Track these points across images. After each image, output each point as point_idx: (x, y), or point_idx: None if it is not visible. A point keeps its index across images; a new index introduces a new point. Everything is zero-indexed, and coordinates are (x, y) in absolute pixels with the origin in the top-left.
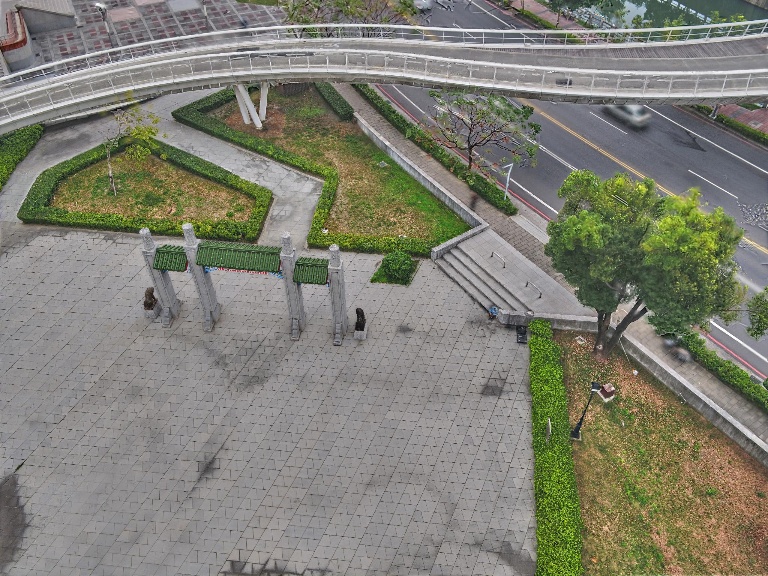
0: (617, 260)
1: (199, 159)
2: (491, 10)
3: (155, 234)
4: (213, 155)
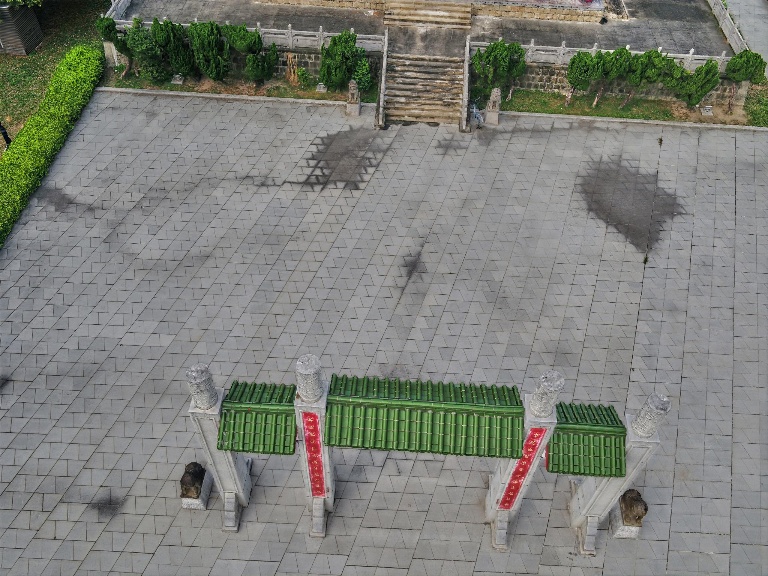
0: None
1: None
2: None
3: None
4: None
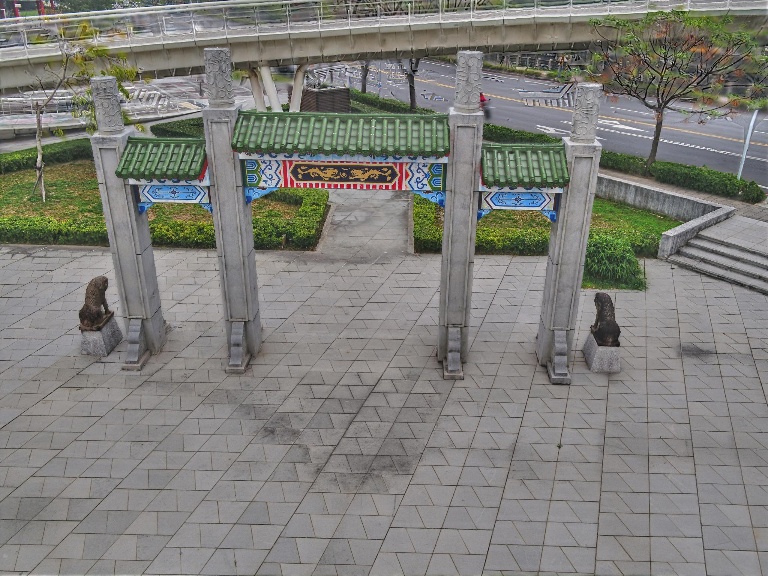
0: None
1: None
2: (549, 83)
3: None
4: None
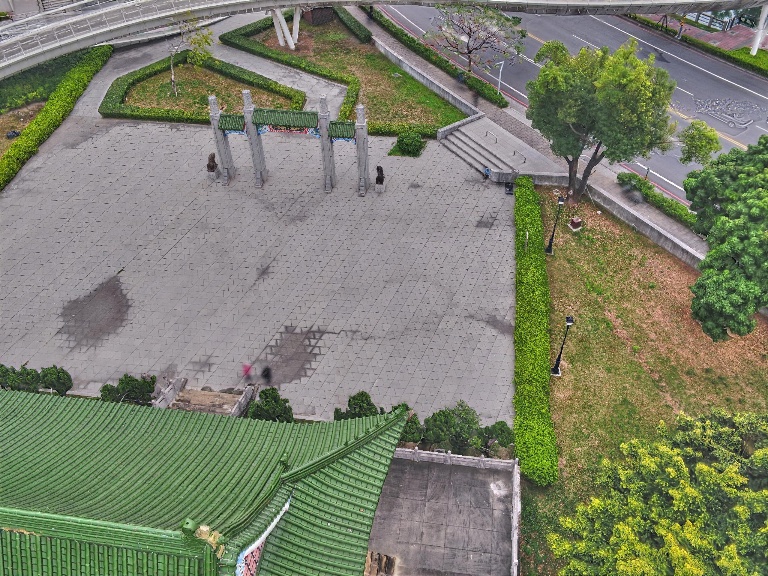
0: (578, 103)
1: (244, 70)
2: None
3: None
4: (255, 68)
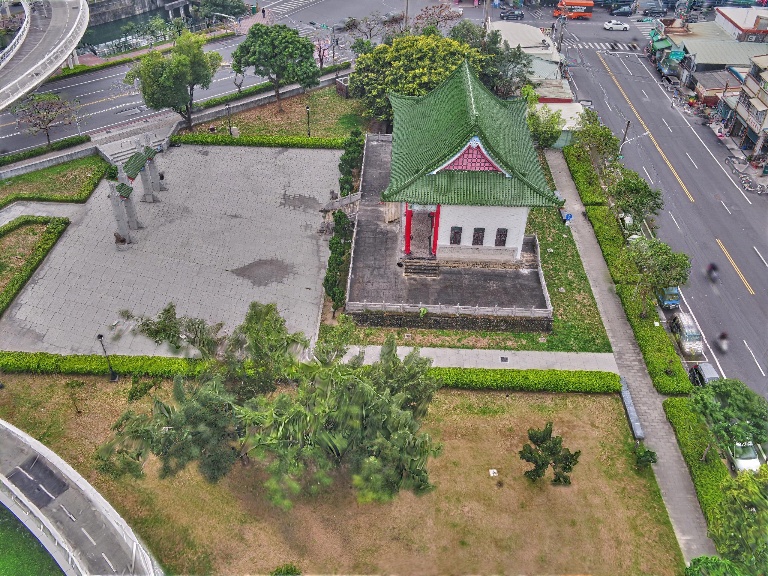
0: None
1: None
2: None
3: (41, 262)
4: None
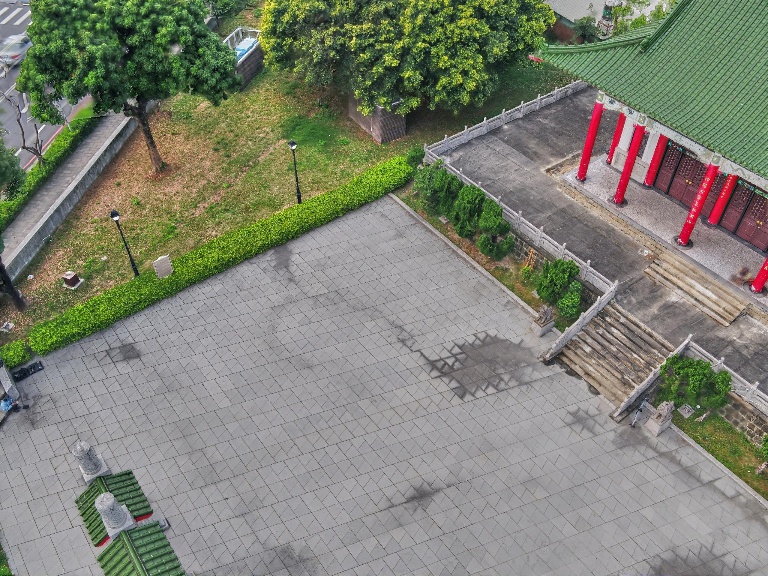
0: None
1: None
2: None
3: None
4: None
